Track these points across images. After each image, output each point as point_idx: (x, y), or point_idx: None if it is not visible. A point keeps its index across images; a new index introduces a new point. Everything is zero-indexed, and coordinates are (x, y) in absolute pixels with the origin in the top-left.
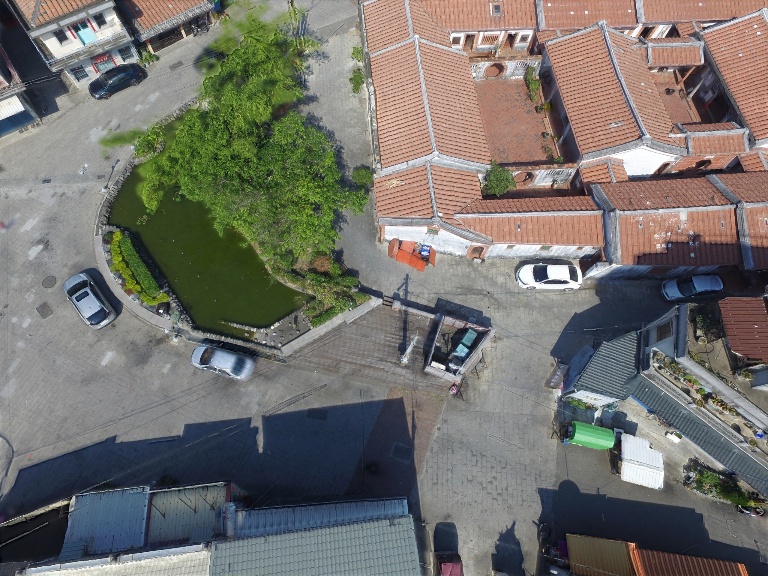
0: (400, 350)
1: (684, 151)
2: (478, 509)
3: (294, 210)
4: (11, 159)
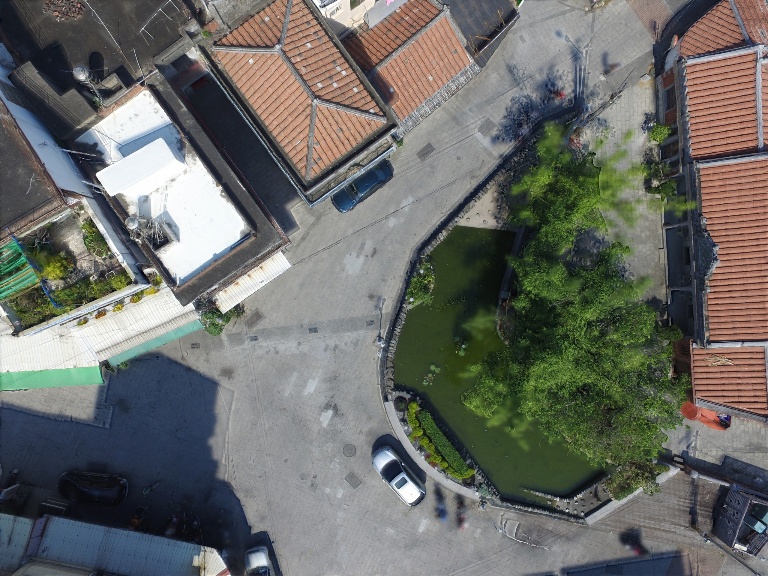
0: (691, 514)
1: None
2: None
3: (644, 436)
4: (265, 301)
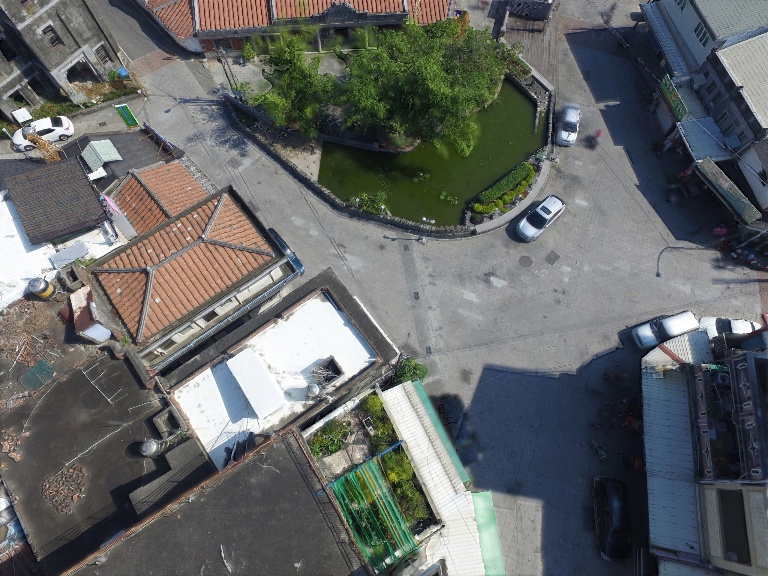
0: (534, 32)
1: None
2: (619, 3)
3: None
4: (391, 340)
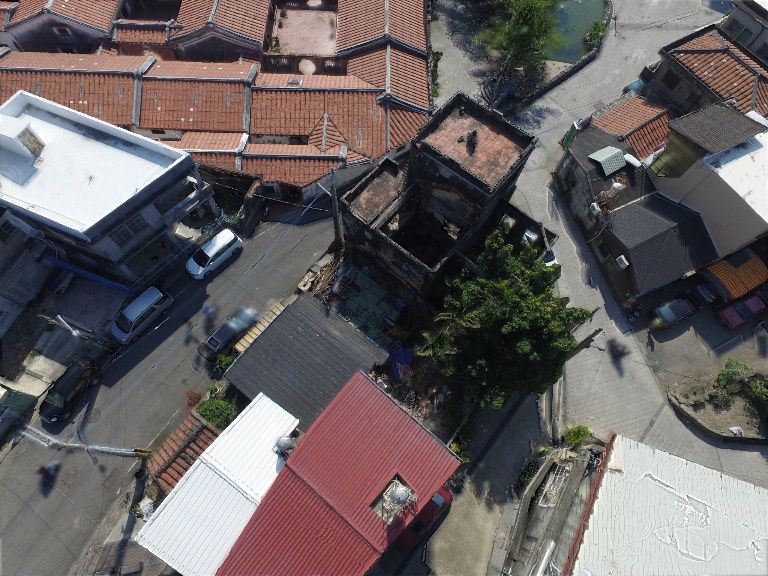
0: None
1: None
2: None
3: None
4: None
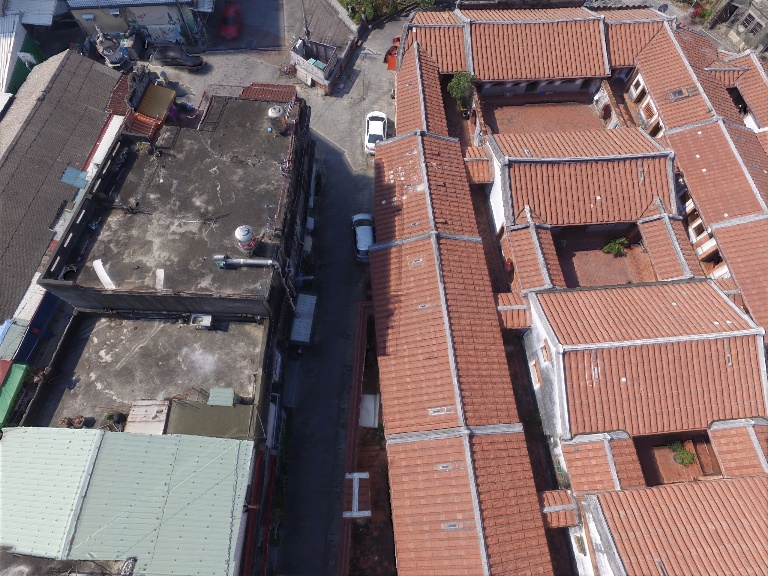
0: None
1: (510, 221)
2: (207, 78)
3: None
4: None
